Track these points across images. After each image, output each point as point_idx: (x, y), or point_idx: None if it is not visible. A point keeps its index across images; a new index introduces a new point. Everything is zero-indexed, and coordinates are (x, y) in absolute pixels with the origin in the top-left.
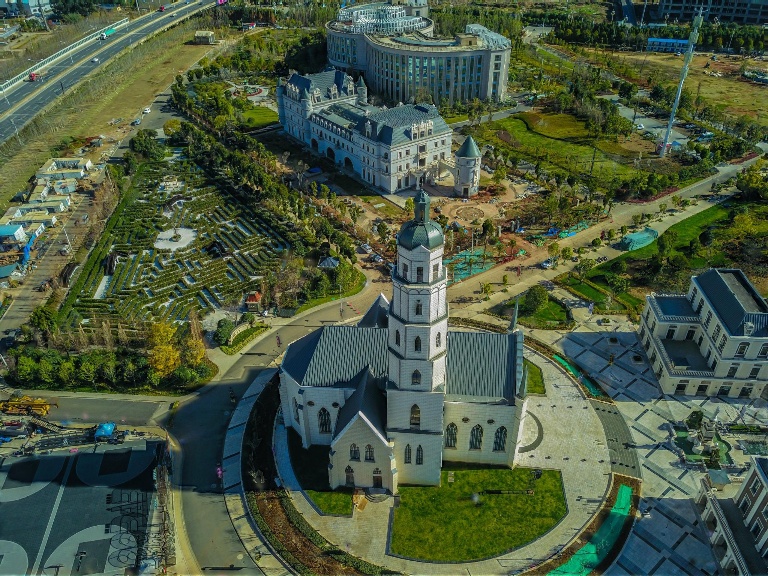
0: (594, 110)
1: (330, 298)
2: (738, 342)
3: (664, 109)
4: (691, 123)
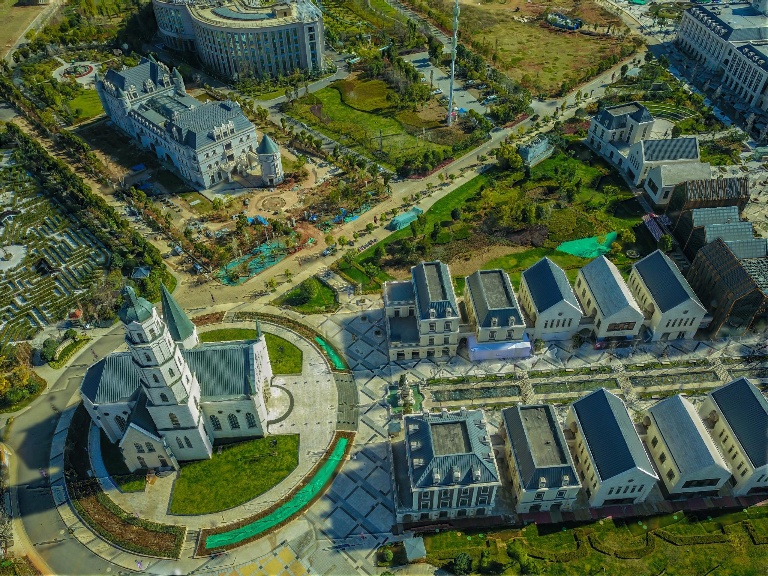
0: (398, 79)
1: None
2: (427, 323)
3: (466, 67)
4: (483, 84)
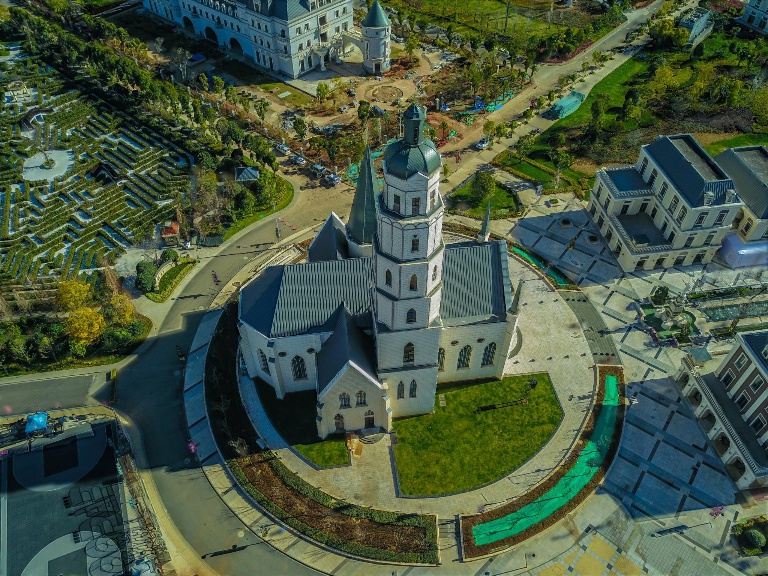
0: None
1: (258, 216)
2: (698, 213)
3: None
4: None
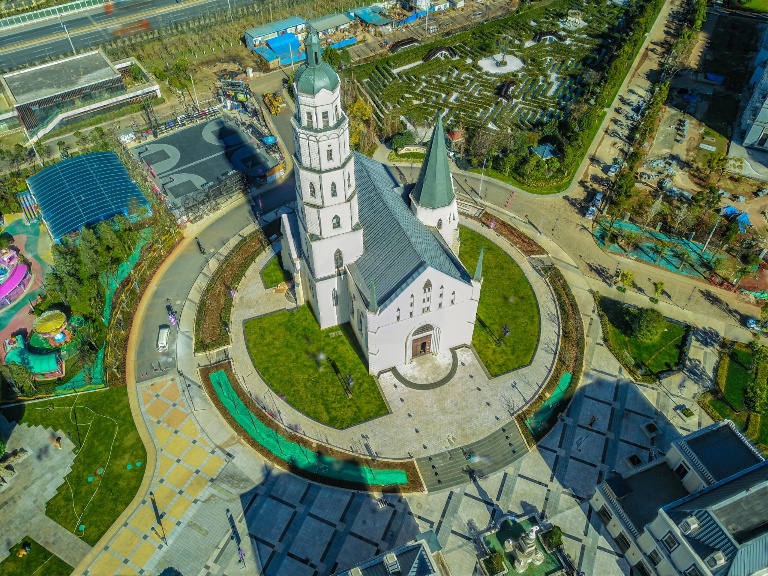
0: None
1: (509, 180)
2: None
3: None
4: None
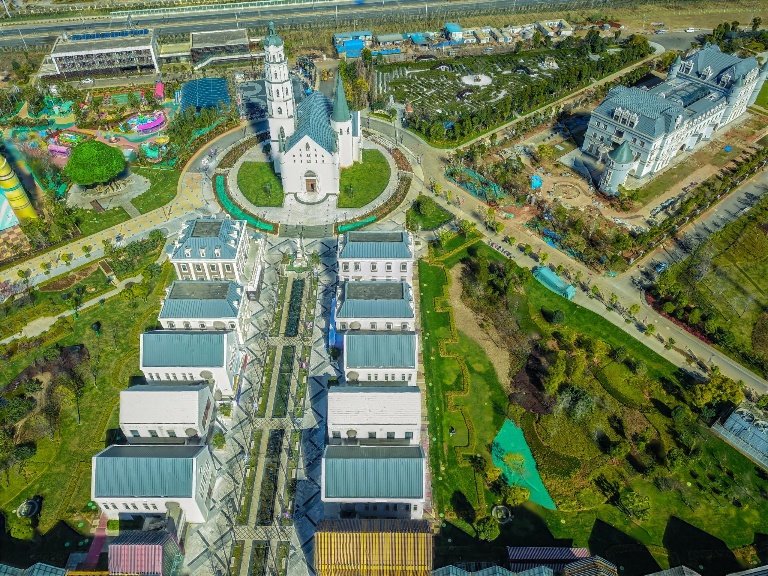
0: None
1: (424, 138)
2: None
3: None
4: None
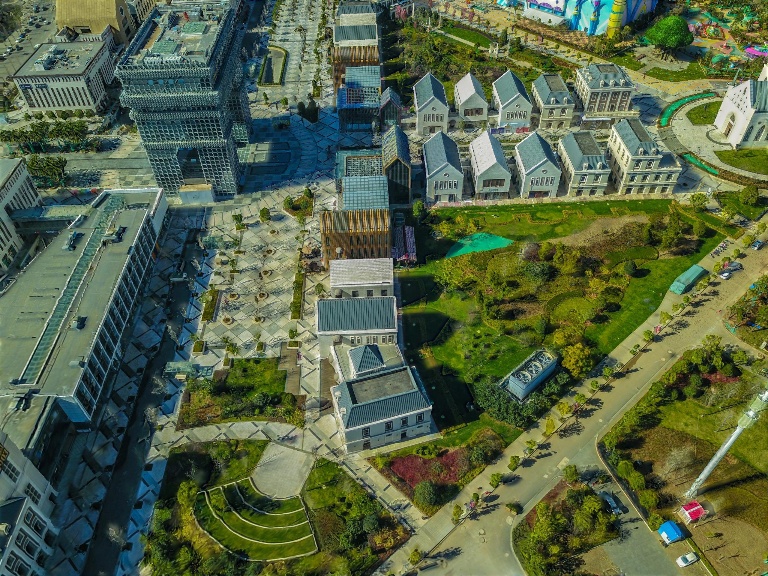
0: None
1: None
2: None
3: None
4: None
